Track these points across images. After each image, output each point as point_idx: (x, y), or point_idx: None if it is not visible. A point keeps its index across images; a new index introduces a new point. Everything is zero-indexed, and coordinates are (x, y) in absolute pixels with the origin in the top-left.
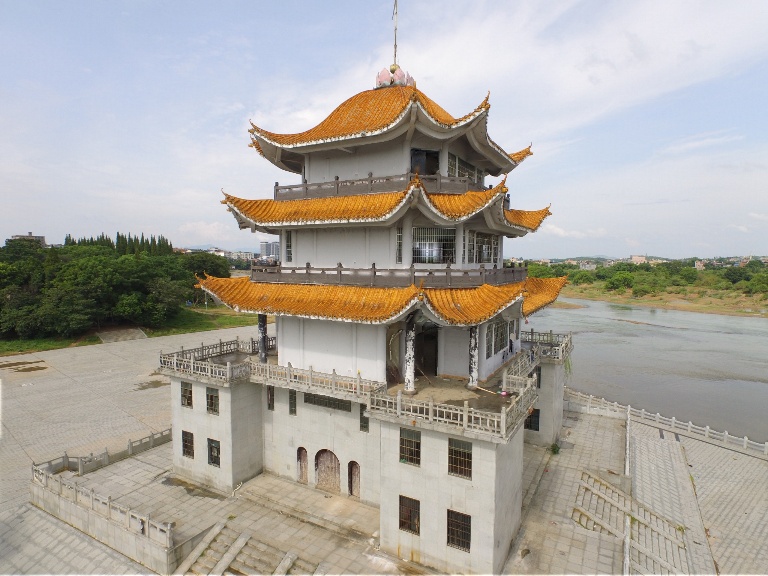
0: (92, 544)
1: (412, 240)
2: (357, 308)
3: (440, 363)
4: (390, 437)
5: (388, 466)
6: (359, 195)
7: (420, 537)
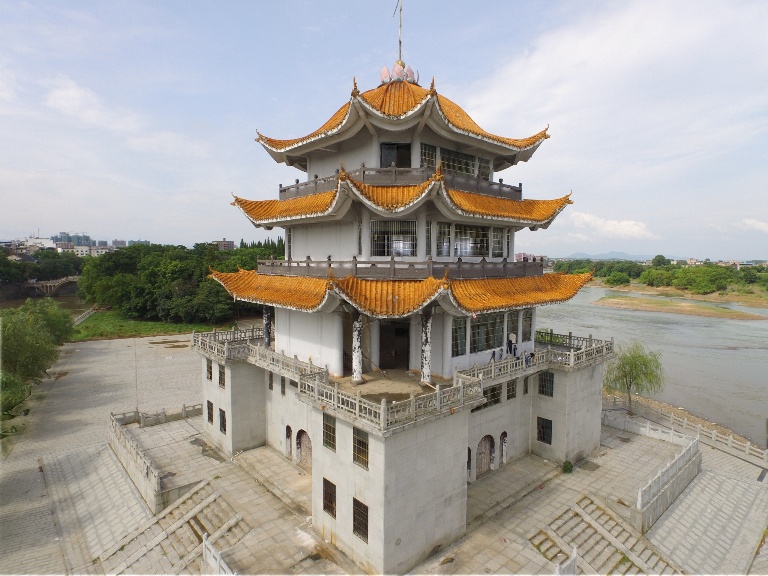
0: (126, 480)
1: (370, 233)
2: (309, 298)
3: (412, 358)
4: (317, 421)
5: (316, 448)
6: (328, 191)
7: (336, 521)
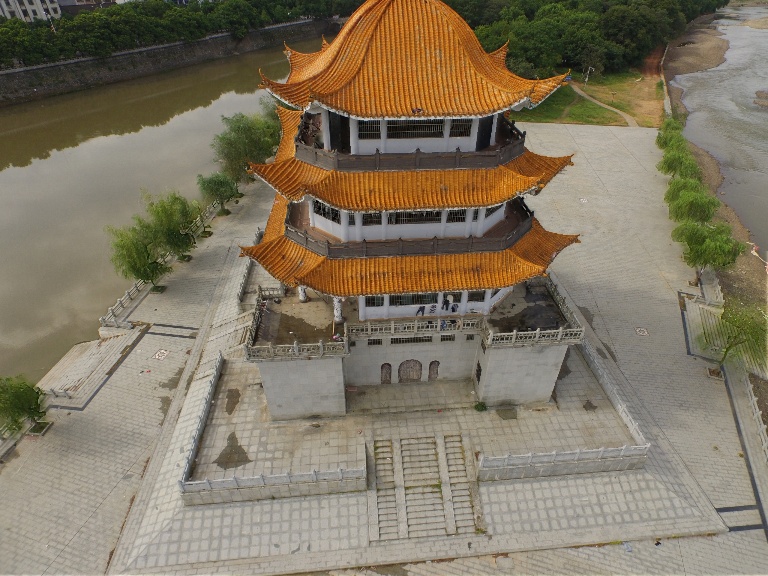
0: None
1: None
2: None
3: None
4: None
5: None
6: None
7: None
